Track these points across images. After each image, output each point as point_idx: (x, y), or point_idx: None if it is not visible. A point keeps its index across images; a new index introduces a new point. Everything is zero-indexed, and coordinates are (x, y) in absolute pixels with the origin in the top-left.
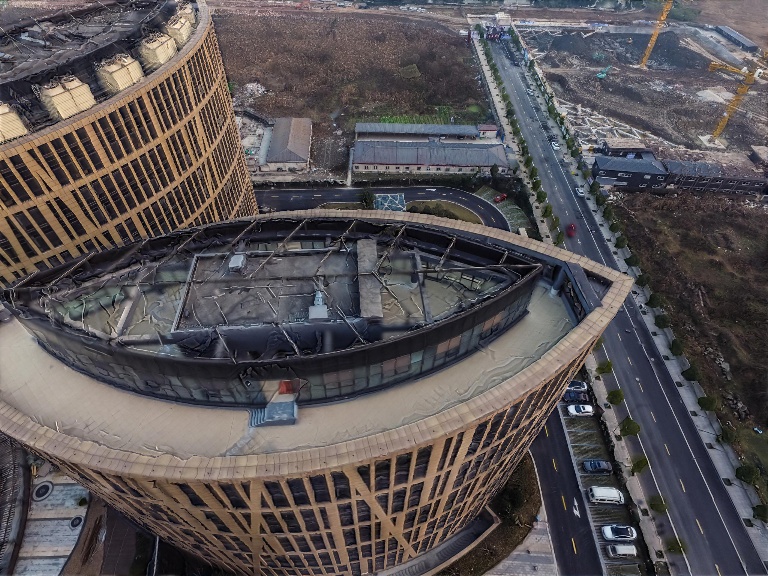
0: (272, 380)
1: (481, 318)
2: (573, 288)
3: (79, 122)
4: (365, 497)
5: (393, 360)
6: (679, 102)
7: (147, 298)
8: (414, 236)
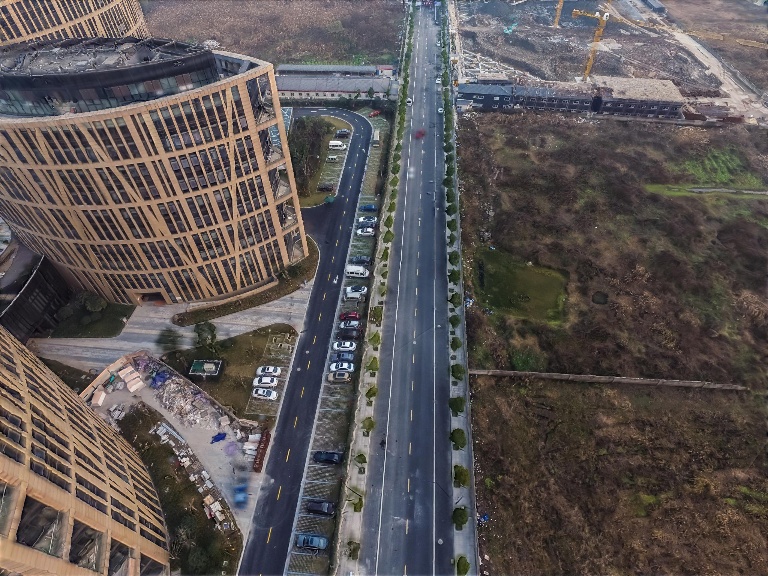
0: (67, 107)
1: (170, 72)
2: None
3: (2, 2)
4: (109, 165)
5: (117, 87)
6: (567, 51)
7: (1, 58)
8: (158, 44)
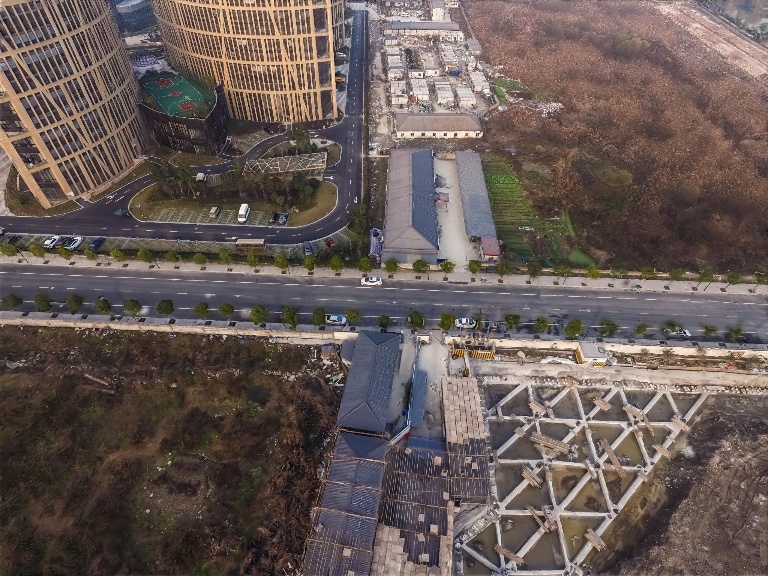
0: None
1: None
2: None
3: None
4: None
5: None
6: None
7: None
8: None
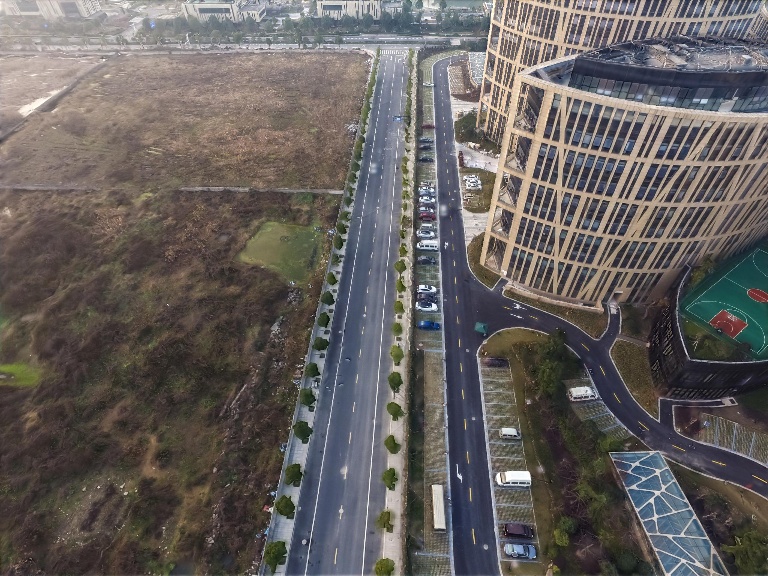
0: None
1: None
2: None
3: None
4: None
5: None
6: None
7: None
8: None
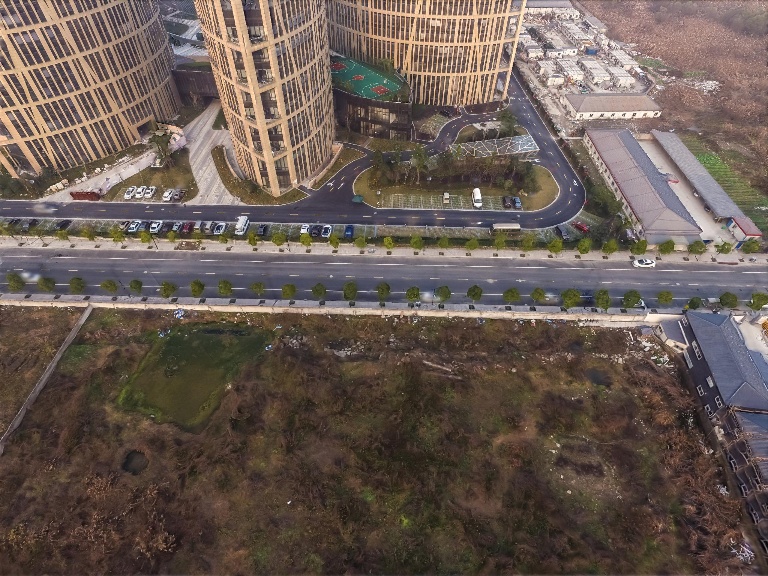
0: None
1: None
2: None
3: None
4: None
5: None
6: None
7: None
8: None
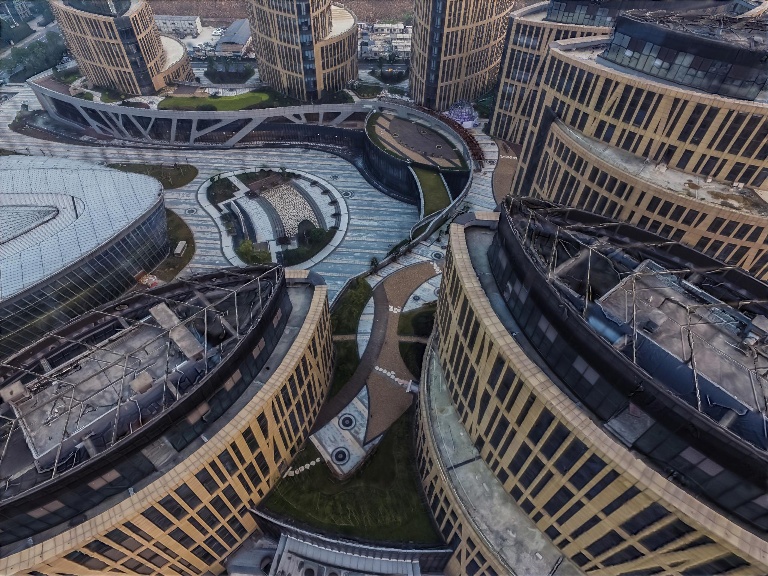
0: None
1: None
2: (746, 7)
3: None
4: None
5: None
6: None
7: None
8: None
